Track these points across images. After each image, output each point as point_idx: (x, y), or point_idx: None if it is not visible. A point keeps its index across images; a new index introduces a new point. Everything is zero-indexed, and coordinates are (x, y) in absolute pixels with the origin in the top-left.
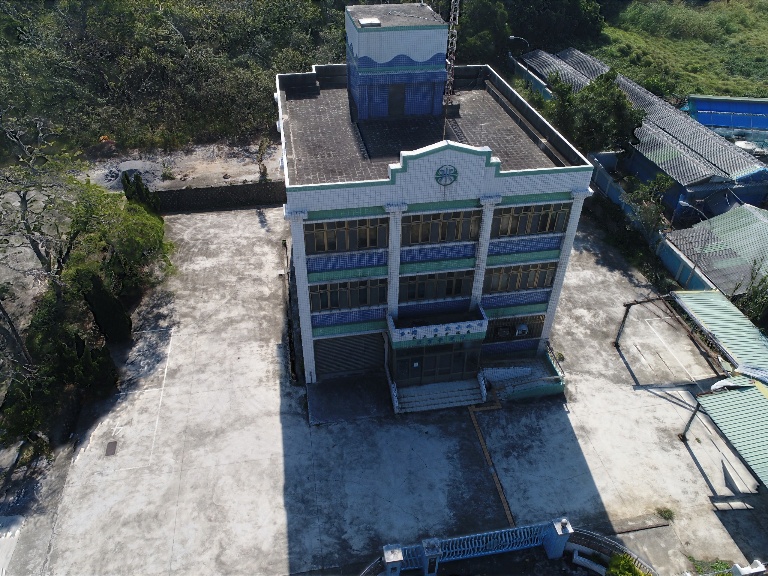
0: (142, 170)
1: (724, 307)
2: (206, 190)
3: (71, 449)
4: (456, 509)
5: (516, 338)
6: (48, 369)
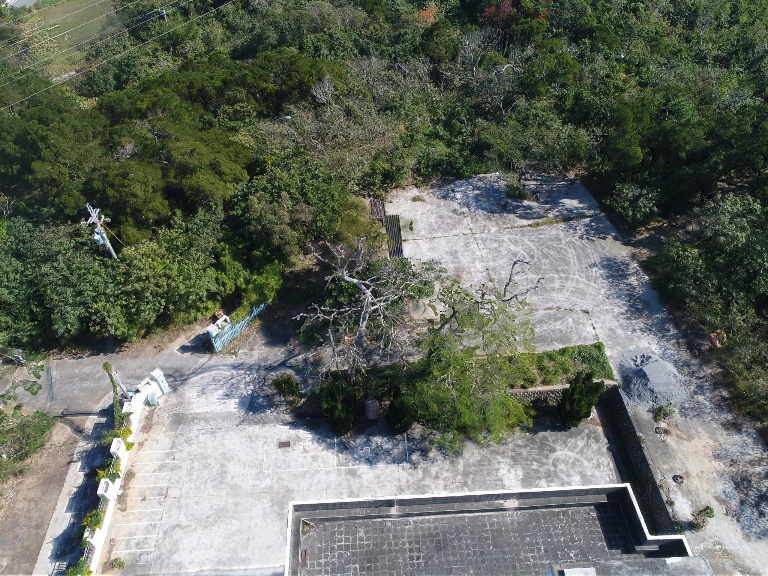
0: (653, 385)
1: None
2: (645, 459)
3: (290, 421)
4: None
5: None
6: (324, 386)
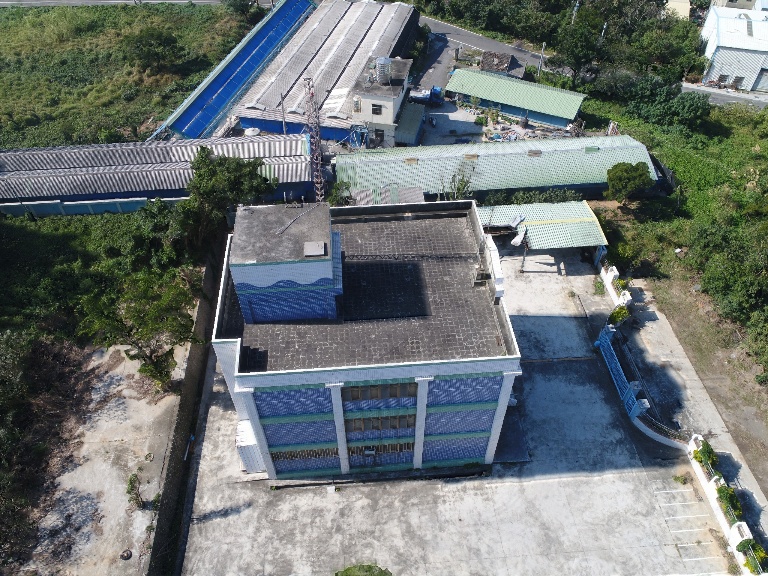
0: None
1: None
2: None
3: None
4: (585, 382)
5: None
6: None
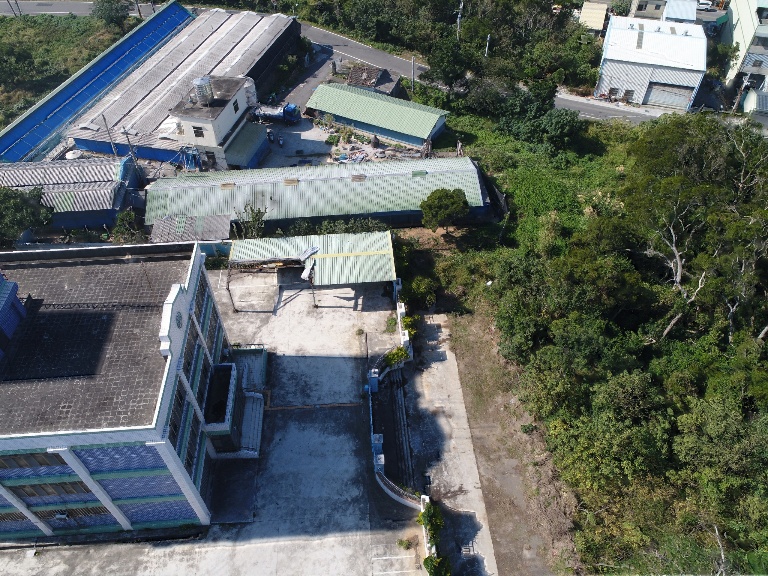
0: None
1: (249, 244)
2: None
3: None
4: (341, 432)
5: (226, 361)
6: None
